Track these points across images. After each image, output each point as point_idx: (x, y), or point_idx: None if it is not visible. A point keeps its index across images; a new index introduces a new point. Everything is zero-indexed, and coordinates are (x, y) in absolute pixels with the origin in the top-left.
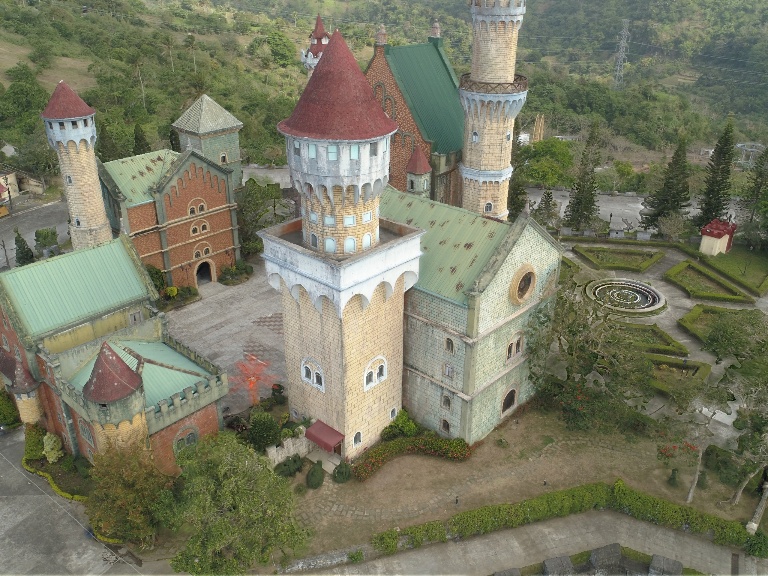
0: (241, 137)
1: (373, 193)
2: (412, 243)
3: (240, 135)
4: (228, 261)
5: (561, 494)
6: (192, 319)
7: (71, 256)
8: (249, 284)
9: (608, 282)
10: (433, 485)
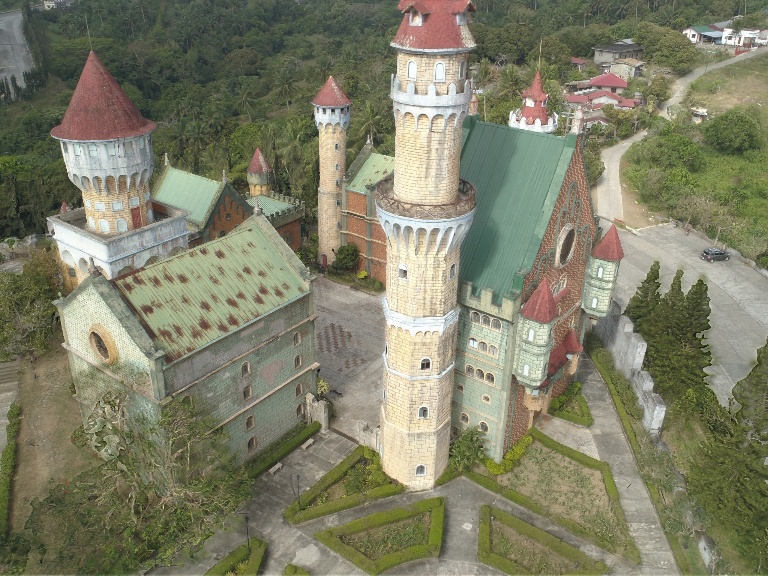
0: None
1: (88, 187)
2: (100, 246)
3: None
4: None
5: (1, 505)
6: (336, 297)
7: (197, 178)
8: None
9: None
10: (59, 432)
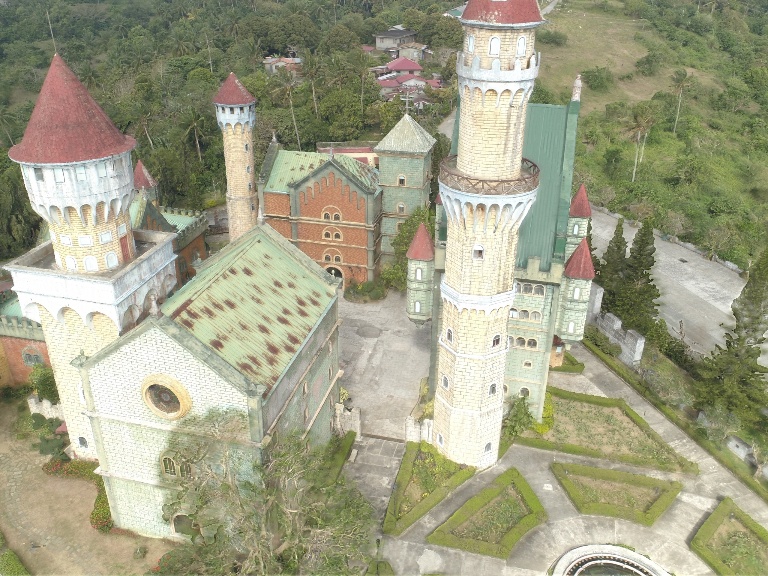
0: (744, 190)
1: None
2: (101, 287)
3: (744, 188)
4: (361, 278)
5: None
6: None
7: None
8: (358, 306)
9: (647, 568)
10: (60, 523)
